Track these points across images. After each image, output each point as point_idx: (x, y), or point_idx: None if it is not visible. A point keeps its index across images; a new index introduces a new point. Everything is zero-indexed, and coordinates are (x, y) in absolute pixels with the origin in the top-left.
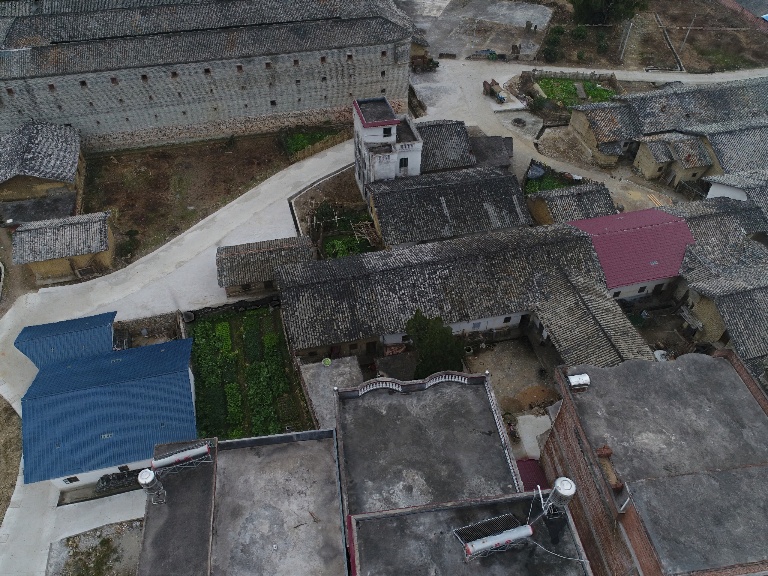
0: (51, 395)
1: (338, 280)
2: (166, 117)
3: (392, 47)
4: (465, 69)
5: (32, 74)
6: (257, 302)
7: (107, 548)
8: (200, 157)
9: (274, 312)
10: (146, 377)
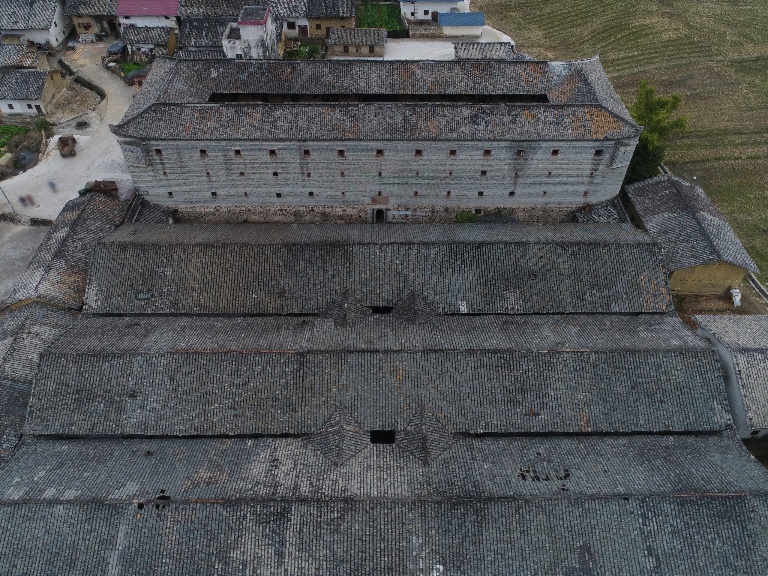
0: None
1: None
2: None
3: None
4: (47, 197)
5: None
6: None
7: None
8: None
9: None
10: None
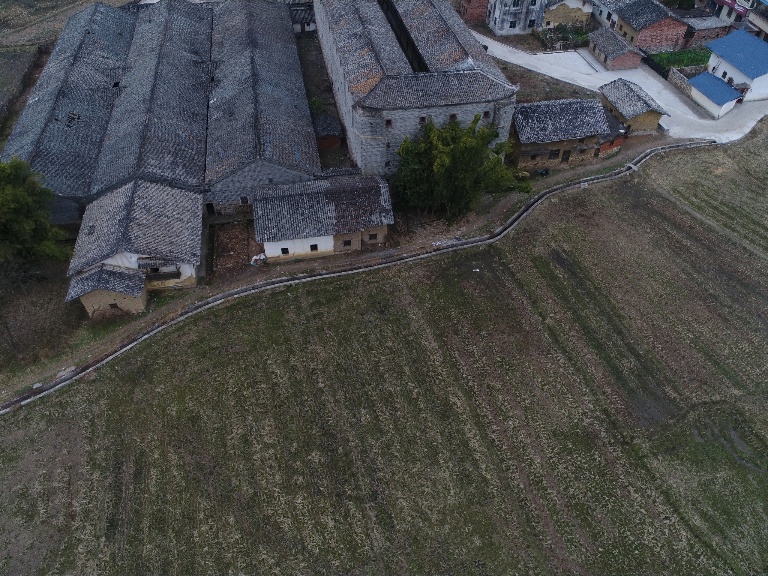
0: None
1: (654, 3)
2: None
3: None
4: None
5: None
6: None
7: None
8: None
9: None
10: None
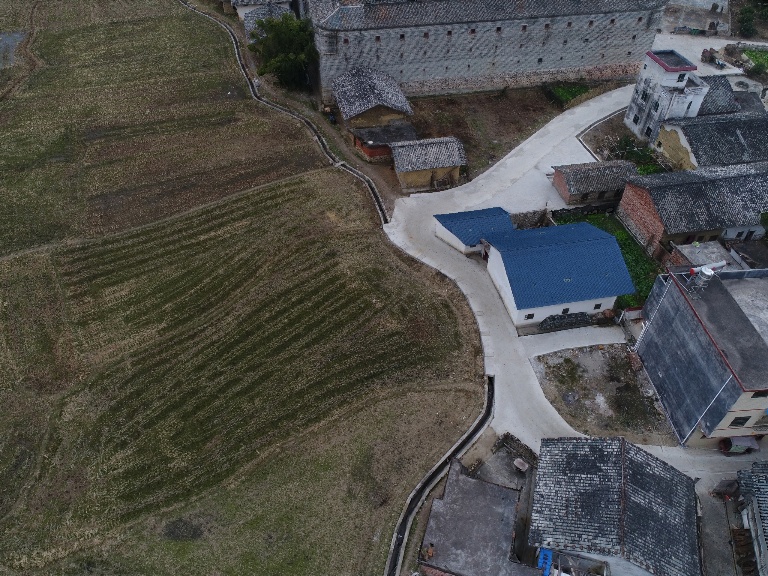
0: (521, 249)
1: (692, 184)
2: (454, 69)
3: (648, 14)
4: (674, 41)
5: (368, 26)
6: (600, 207)
7: (572, 364)
8: (481, 104)
9: (610, 217)
10: (586, 240)
